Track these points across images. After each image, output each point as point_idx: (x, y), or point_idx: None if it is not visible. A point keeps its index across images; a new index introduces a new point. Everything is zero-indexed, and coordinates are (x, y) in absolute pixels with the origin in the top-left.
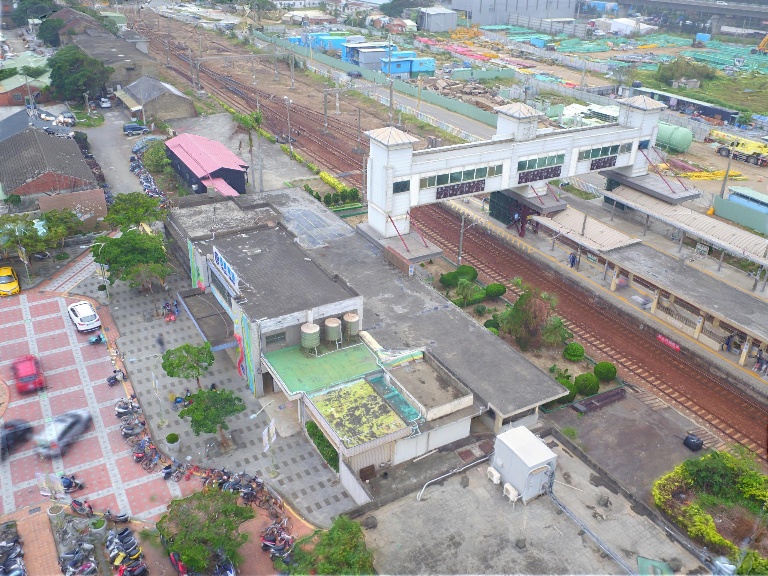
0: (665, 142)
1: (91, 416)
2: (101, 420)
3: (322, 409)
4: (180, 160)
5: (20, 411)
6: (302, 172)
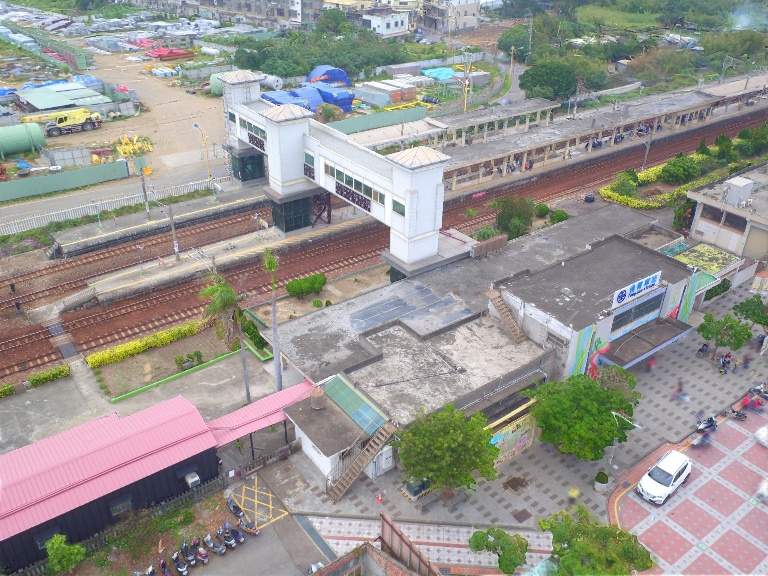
0: (27, 145)
1: None
2: None
3: (717, 270)
4: (65, 516)
5: None
6: (54, 391)
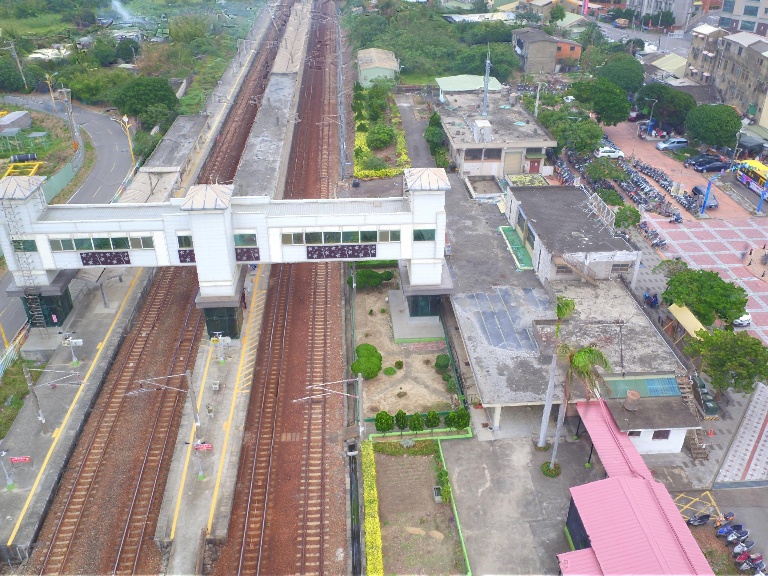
0: None
1: (683, 249)
2: (675, 246)
3: None
4: None
5: (732, 260)
6: None
